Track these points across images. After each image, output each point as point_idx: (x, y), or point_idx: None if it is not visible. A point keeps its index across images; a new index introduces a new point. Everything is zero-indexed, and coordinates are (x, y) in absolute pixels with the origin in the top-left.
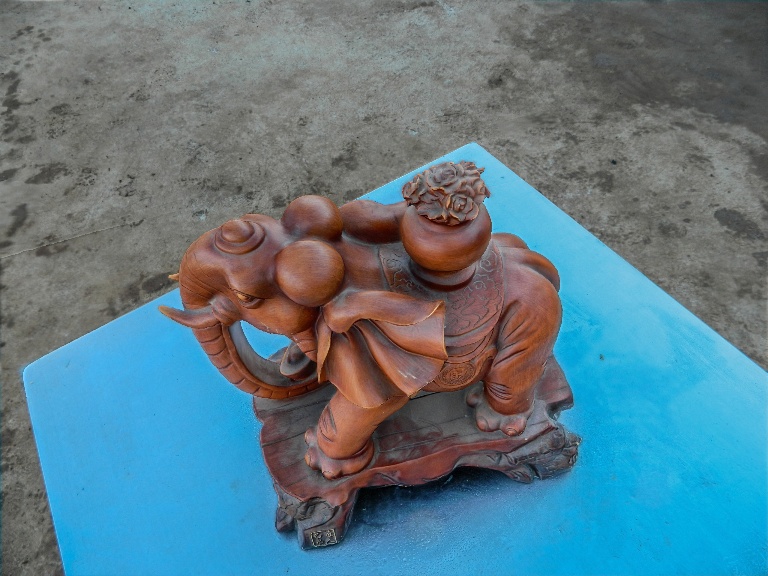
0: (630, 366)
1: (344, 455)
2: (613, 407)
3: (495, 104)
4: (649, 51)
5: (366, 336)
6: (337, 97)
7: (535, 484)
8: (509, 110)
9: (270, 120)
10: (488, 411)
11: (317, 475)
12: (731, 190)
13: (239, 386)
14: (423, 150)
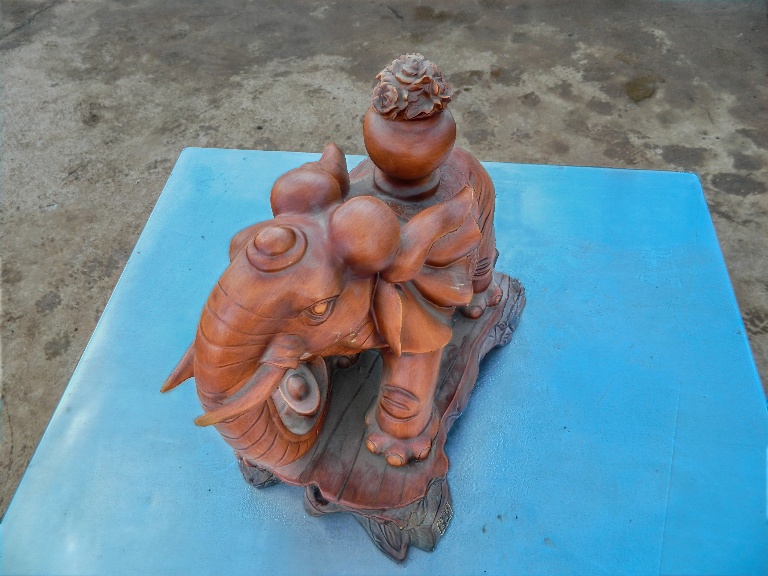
0: None
1: (427, 421)
2: (498, 250)
3: (111, 138)
4: (201, 33)
5: None
6: None
7: (514, 337)
8: (130, 136)
9: None
10: None
11: (411, 467)
12: (355, 101)
13: (284, 460)
14: (80, 216)
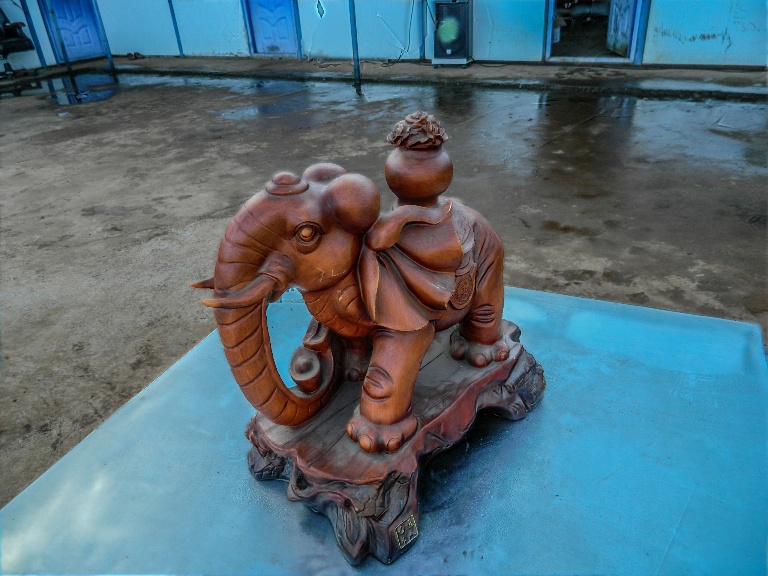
0: (525, 327)
1: (401, 413)
2: (535, 351)
3: None
4: None
5: (397, 264)
6: (107, 318)
7: (529, 416)
8: None
9: (37, 357)
10: (479, 347)
11: (380, 456)
12: None
13: (269, 404)
14: None
